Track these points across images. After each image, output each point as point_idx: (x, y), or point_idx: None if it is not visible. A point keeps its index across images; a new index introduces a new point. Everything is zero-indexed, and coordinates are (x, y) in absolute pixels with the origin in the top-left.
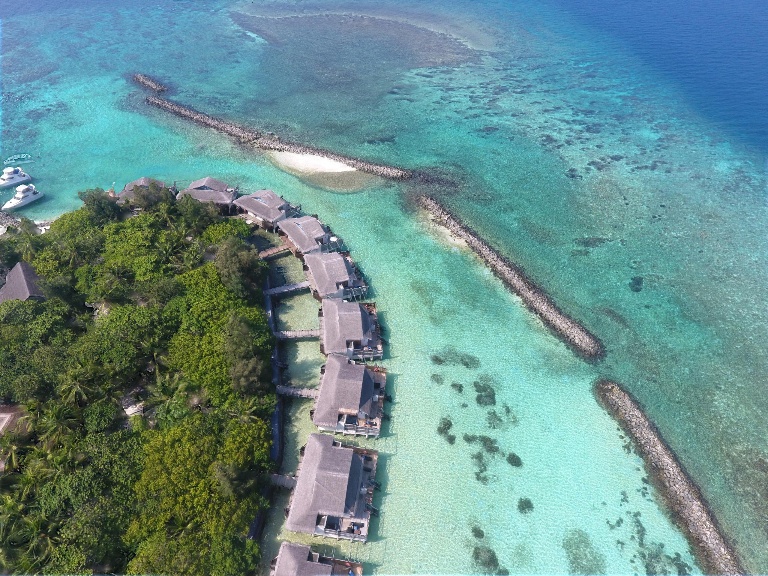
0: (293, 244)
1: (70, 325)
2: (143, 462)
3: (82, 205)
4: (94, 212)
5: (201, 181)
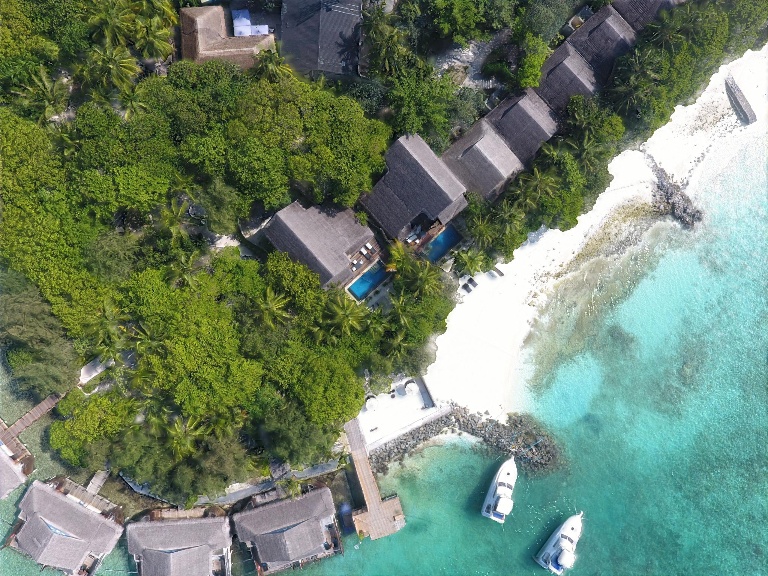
0: (2, 440)
1: (201, 175)
2: (20, 3)
3: (407, 499)
4: (296, 414)
5: (184, 570)
